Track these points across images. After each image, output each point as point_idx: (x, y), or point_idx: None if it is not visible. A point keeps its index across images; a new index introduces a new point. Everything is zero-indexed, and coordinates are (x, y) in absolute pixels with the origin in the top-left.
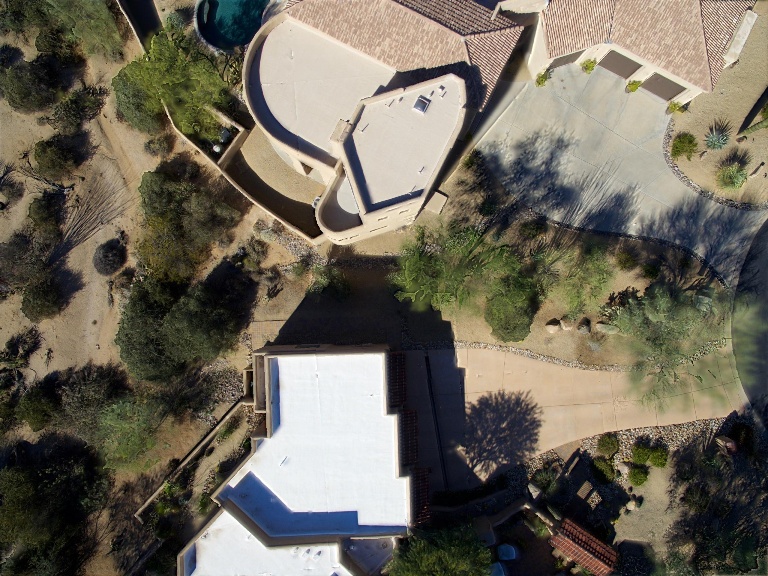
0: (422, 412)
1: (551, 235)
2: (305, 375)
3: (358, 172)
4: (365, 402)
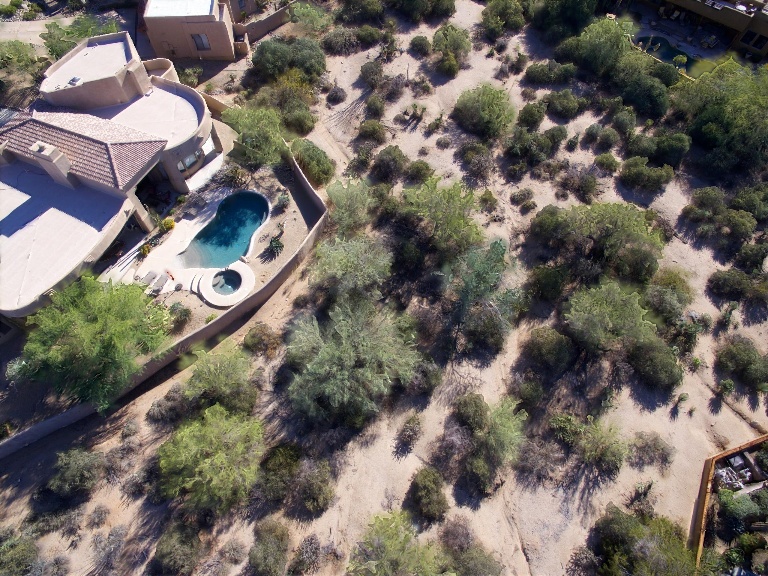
0: (144, 35)
1: (27, 101)
2: (195, 13)
3: (129, 53)
4: (162, 5)
